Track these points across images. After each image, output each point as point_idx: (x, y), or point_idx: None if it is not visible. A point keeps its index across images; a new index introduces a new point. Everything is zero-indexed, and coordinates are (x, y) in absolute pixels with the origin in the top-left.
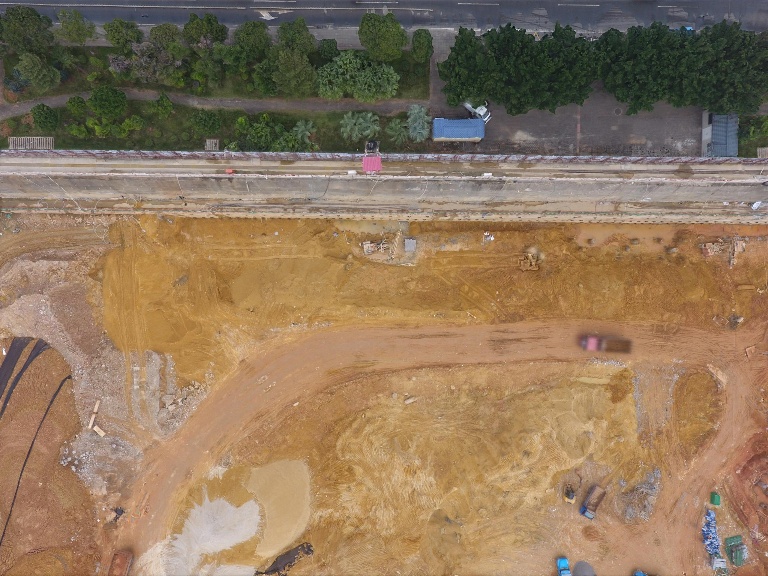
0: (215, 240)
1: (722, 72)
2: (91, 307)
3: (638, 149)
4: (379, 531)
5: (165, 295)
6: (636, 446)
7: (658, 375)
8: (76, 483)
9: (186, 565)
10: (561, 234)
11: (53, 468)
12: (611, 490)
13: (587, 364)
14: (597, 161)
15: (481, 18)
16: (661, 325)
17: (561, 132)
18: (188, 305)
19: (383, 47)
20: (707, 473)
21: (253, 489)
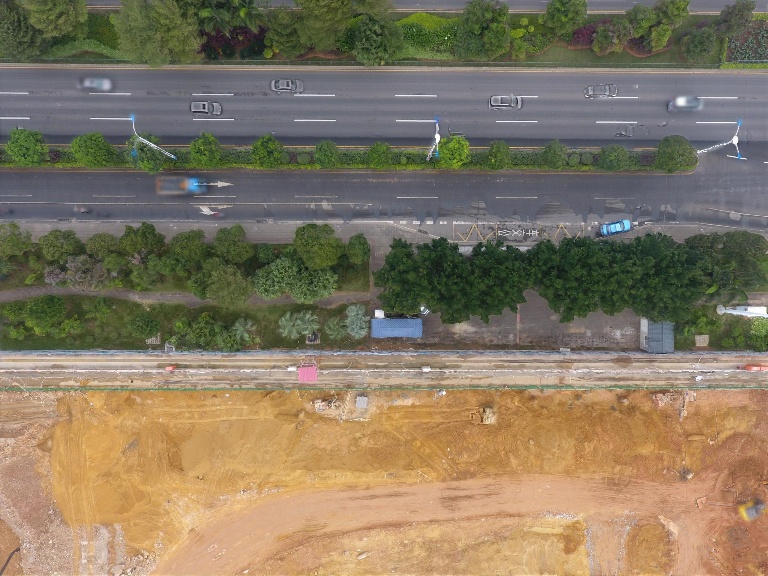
0: (166, 402)
1: (652, 288)
2: (40, 477)
3: (577, 338)
4: None
5: (114, 464)
6: None
7: (610, 527)
8: None
9: None
10: None
11: None
12: None
13: (539, 518)
14: (536, 352)
15: (420, 211)
16: (612, 478)
17: (501, 322)
18: (137, 475)
19: (317, 262)
20: None
21: None
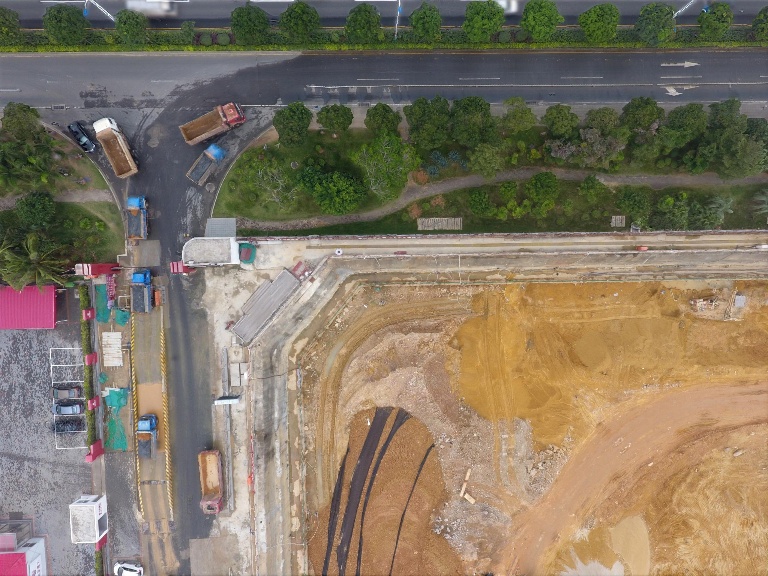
0: (556, 303)
1: None
2: (448, 375)
3: None
4: None
5: (521, 361)
6: None
7: None
8: (450, 550)
9: None
10: None
11: (426, 536)
12: None
13: None
14: None
15: None
16: None
17: None
18: (546, 371)
19: None
20: None
21: (618, 550)
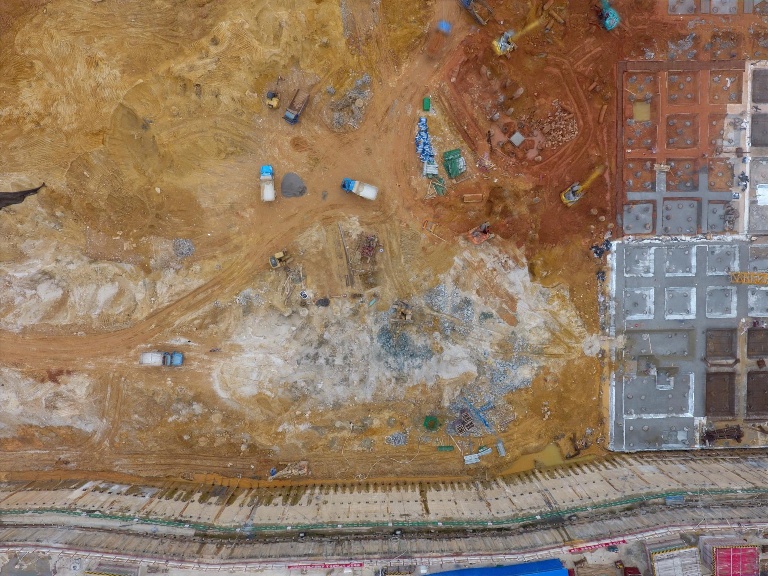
0: None
1: None
2: None
3: None
4: (60, 126)
5: None
6: (345, 53)
7: None
8: None
9: None
10: None
11: None
12: (320, 99)
13: None
14: None
15: None
16: None
17: None
18: None
19: None
20: (419, 79)
21: None
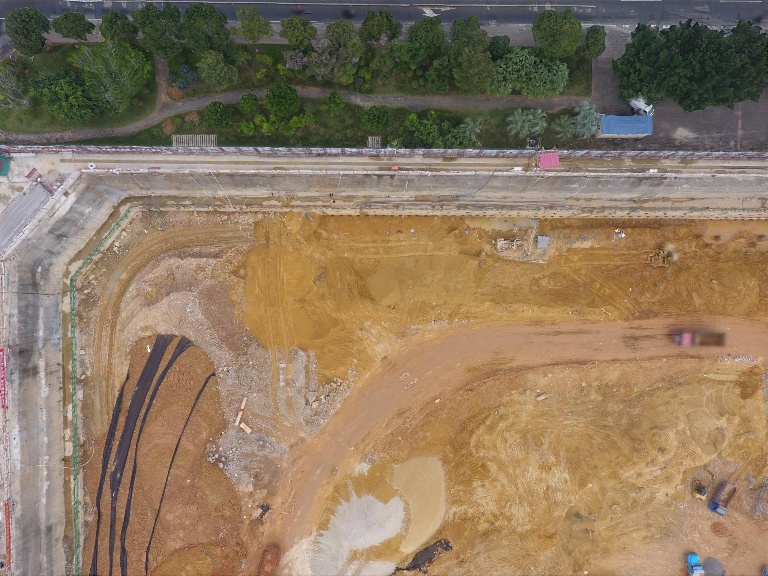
0: (351, 237)
1: None
2: (233, 304)
3: None
4: (514, 527)
5: (307, 292)
6: (764, 442)
7: None
8: (223, 480)
9: (334, 561)
10: (690, 231)
11: (200, 465)
12: (739, 486)
13: (719, 360)
14: (759, 157)
15: (643, 14)
16: None
17: (722, 128)
18: (330, 302)
19: (563, 43)
20: None
21: (398, 485)
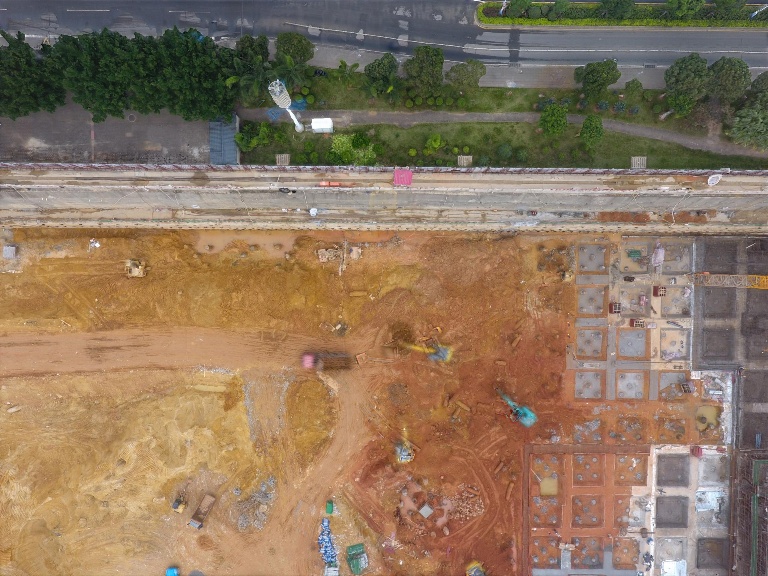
0: None
1: (170, 79)
2: None
3: (154, 156)
4: None
5: None
6: (252, 454)
7: (268, 383)
8: None
9: None
10: (173, 240)
11: None
12: (227, 499)
13: (192, 372)
14: (108, 168)
15: None
16: (268, 332)
17: (74, 139)
18: None
19: None
20: (323, 481)
21: None
